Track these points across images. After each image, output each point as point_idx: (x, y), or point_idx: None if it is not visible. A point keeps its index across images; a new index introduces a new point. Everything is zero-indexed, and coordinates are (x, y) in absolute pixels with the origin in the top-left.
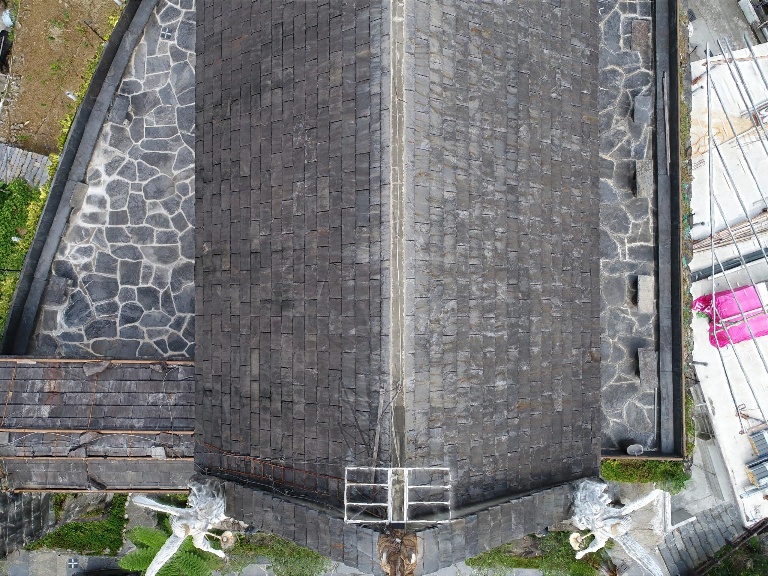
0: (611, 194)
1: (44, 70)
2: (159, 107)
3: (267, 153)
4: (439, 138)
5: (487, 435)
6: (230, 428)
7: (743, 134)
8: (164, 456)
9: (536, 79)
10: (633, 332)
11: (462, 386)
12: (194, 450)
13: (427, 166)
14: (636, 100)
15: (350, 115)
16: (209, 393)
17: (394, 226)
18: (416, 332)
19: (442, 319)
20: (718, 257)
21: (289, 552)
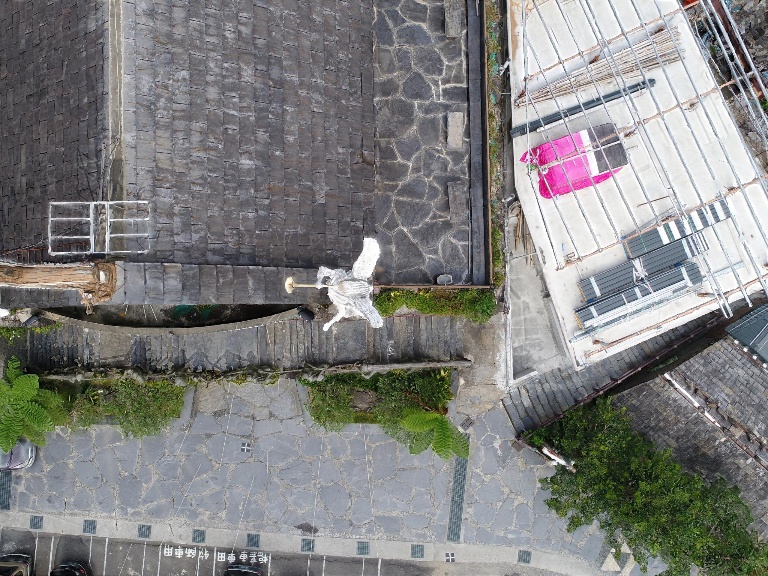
0: (425, 37)
1: None
2: None
3: None
4: None
5: (229, 208)
6: (8, 228)
7: None
8: None
9: None
10: (448, 171)
11: (197, 155)
12: None
13: None
14: None
15: None
16: None
17: None
18: (138, 92)
19: (171, 86)
20: (546, 109)
21: (131, 402)
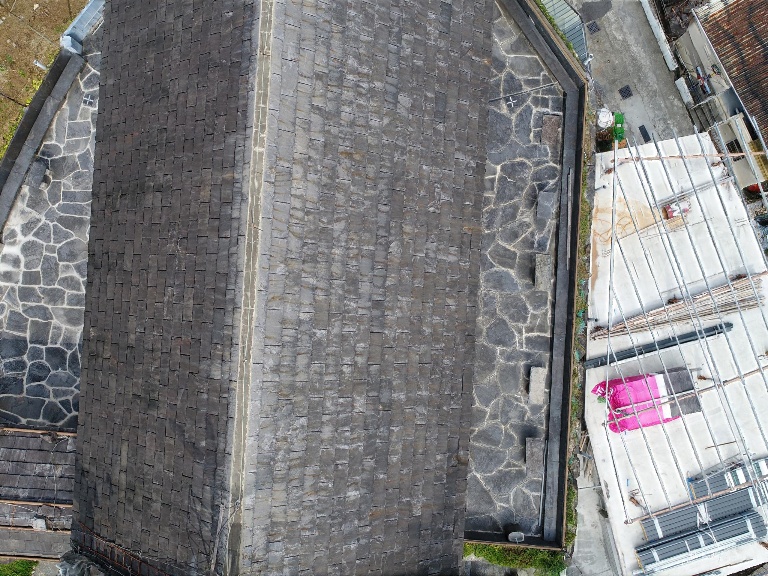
0: (512, 284)
1: None
2: (77, 172)
3: (146, 253)
4: (297, 262)
5: (334, 544)
6: (101, 512)
7: (654, 225)
8: (44, 528)
9: (412, 195)
10: (525, 420)
11: (309, 499)
12: (71, 526)
13: (282, 290)
14: (540, 195)
15: (214, 233)
16: (86, 474)
17: (242, 349)
18: (259, 451)
19: (290, 436)
20: (621, 345)
21: None
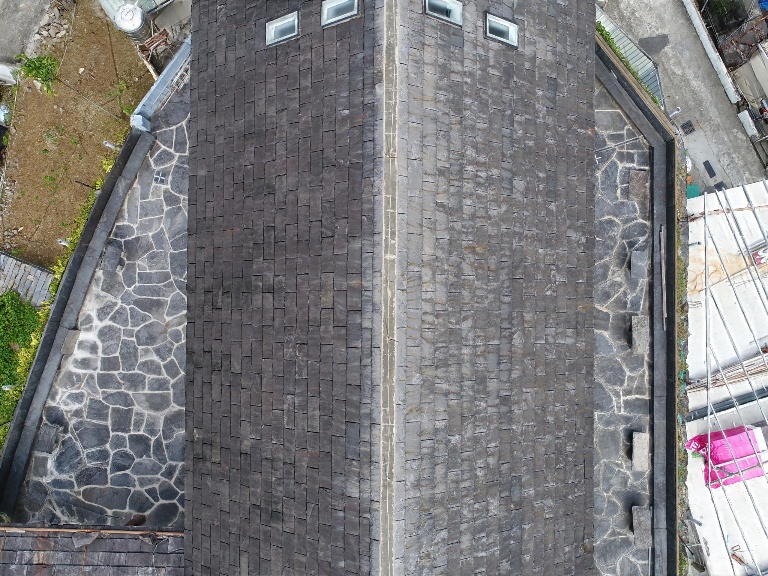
0: (607, 346)
1: (38, 176)
2: (152, 252)
3: (258, 356)
4: (431, 368)
5: None
6: None
7: (741, 273)
8: None
9: (530, 281)
10: (627, 486)
11: None
12: None
13: (418, 400)
14: (633, 255)
15: (341, 342)
16: None
17: (384, 468)
18: (406, 573)
19: (432, 552)
20: (714, 397)
21: None
